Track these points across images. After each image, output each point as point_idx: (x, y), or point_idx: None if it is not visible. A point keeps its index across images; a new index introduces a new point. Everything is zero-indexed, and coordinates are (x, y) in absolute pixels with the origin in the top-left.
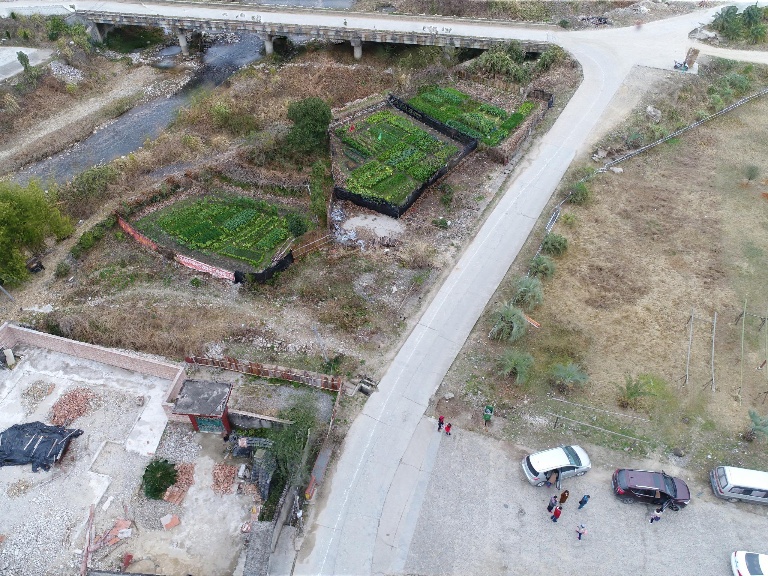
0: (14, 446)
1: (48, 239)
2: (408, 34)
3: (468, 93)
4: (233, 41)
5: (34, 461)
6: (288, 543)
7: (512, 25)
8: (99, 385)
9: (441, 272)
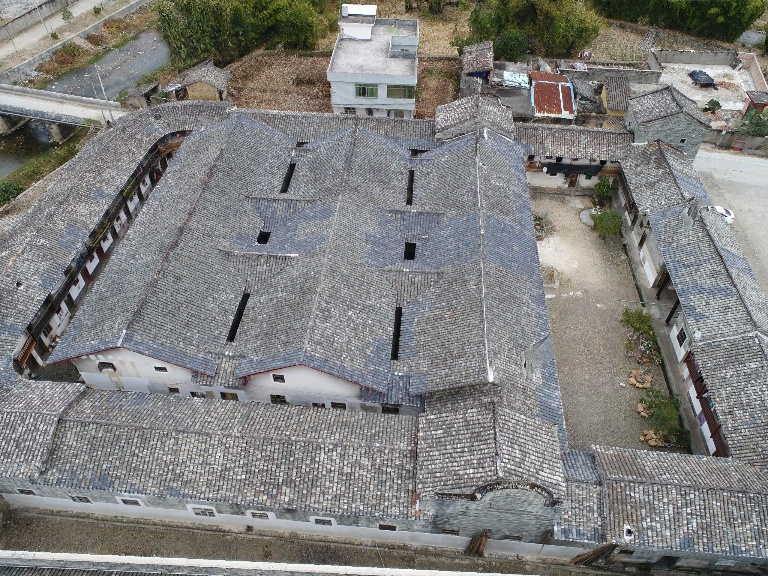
0: (700, 74)
1: None
2: None
3: None
4: None
5: (697, 80)
6: (707, 146)
7: None
8: (744, 91)
9: None
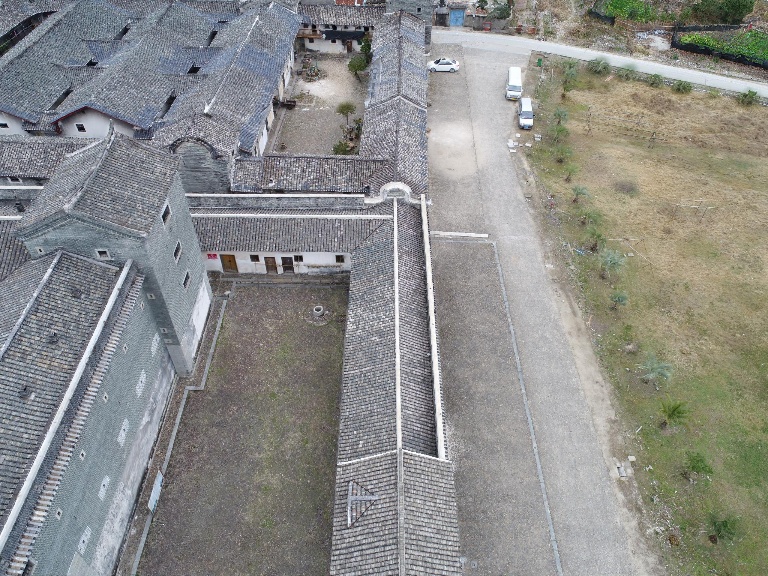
0: None
1: None
2: None
3: None
4: None
5: None
6: None
7: None
8: None
9: (629, 55)
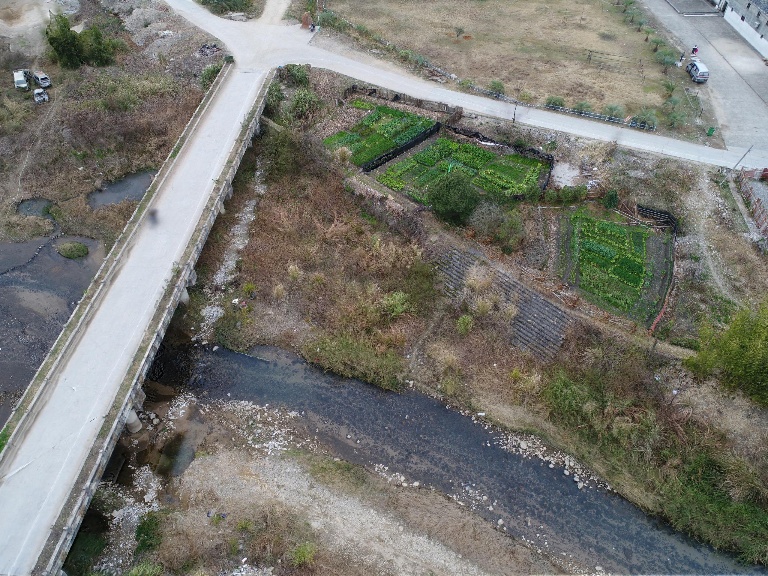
0: None
1: (697, 400)
2: (243, 143)
3: (334, 132)
4: None
5: None
6: None
7: (220, 86)
8: None
9: None
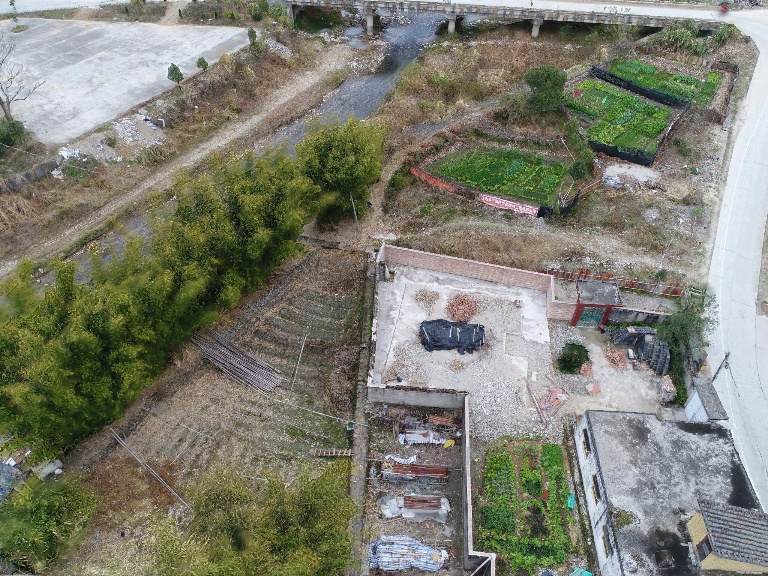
0: (439, 335)
1: None
2: (590, 13)
3: (655, 65)
4: (406, 23)
5: (461, 346)
6: None
7: (677, 6)
8: (474, 293)
9: (712, 208)
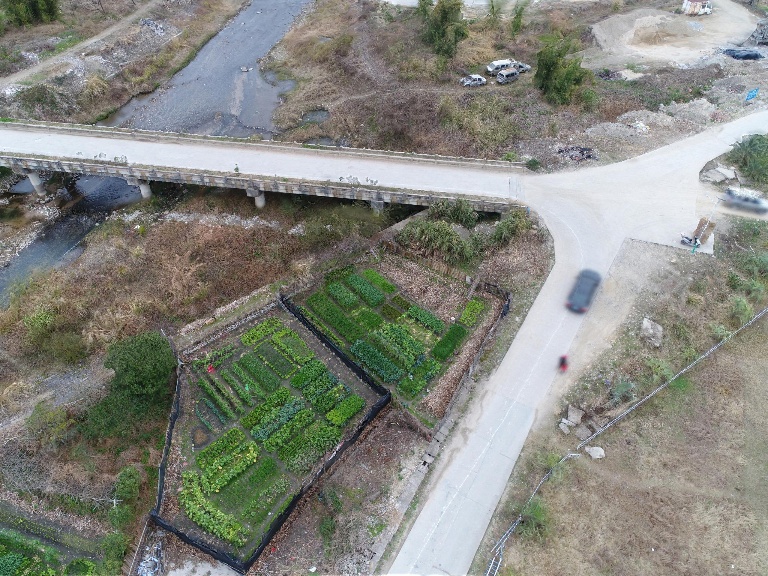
0: None
1: None
2: (320, 185)
3: (395, 280)
4: None
5: None
6: None
7: (464, 165)
8: None
9: None
